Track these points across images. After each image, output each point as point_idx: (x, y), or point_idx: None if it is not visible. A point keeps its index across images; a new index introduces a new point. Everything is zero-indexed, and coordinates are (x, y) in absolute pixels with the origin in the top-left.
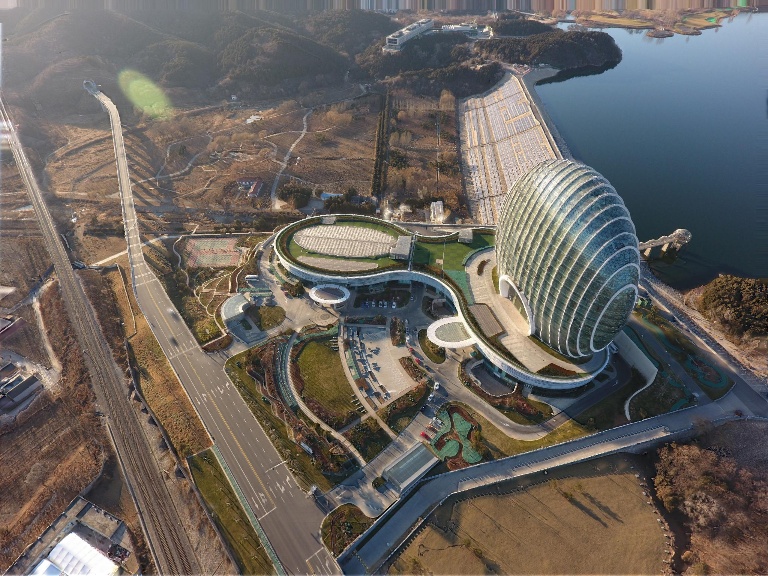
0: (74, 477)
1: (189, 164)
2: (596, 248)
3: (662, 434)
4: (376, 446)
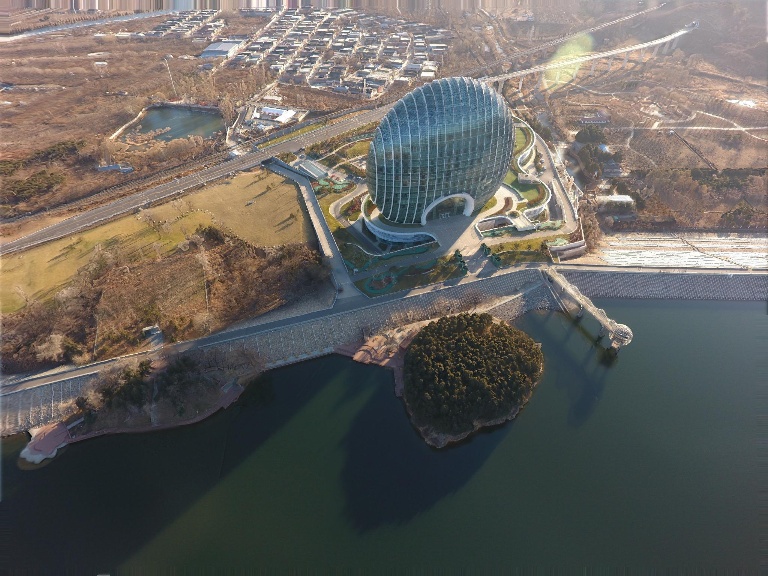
0: (316, 105)
1: (614, 93)
2: None
3: (327, 254)
4: (327, 163)
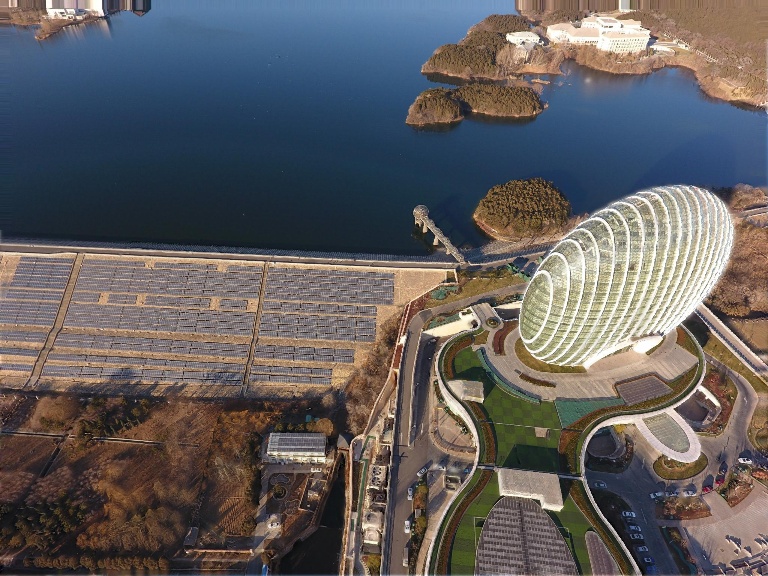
0: None
1: None
2: (729, 233)
3: None
4: None
